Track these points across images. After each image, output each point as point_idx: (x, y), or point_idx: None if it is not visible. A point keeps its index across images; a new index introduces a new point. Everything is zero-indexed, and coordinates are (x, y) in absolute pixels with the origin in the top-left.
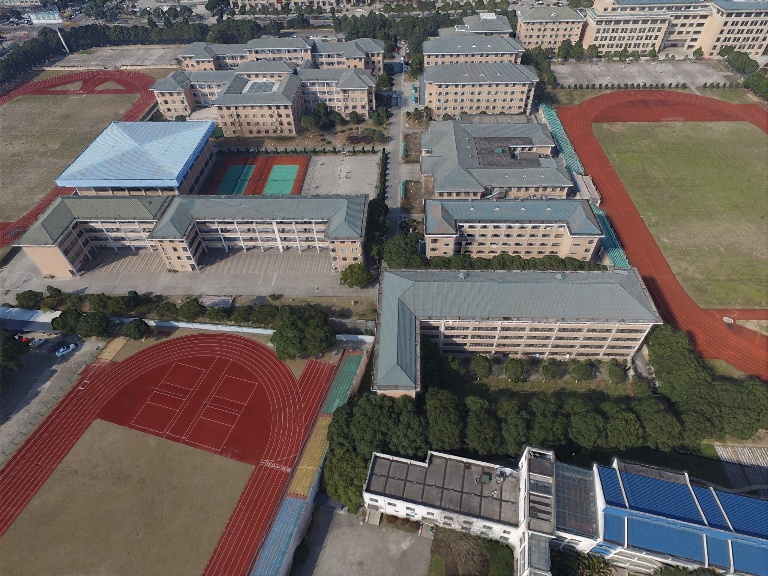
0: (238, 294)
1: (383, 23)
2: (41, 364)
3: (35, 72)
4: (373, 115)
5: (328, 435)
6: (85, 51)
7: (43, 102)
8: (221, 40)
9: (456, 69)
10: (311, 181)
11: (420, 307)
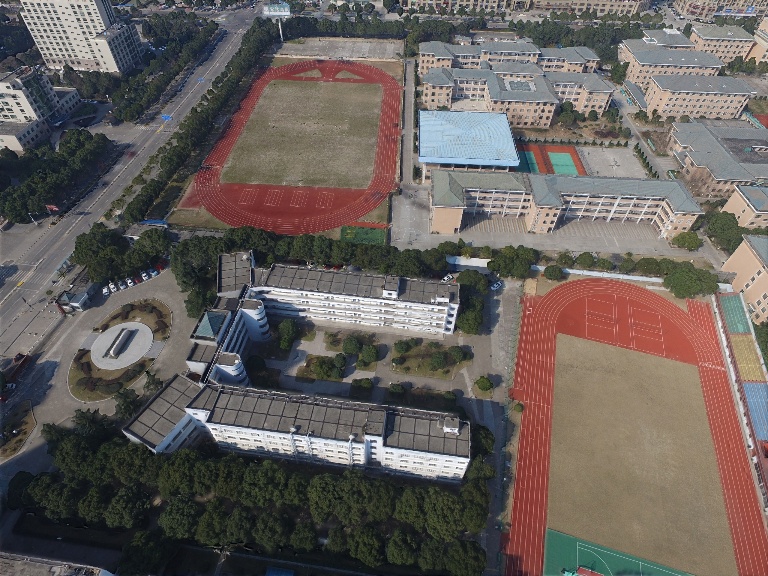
0: (596, 251)
1: (568, 31)
2: (484, 295)
3: (266, 58)
4: (609, 114)
5: (763, 343)
6: (295, 40)
7: (300, 87)
8: (422, 38)
9: (688, 80)
10: (589, 167)
11: None
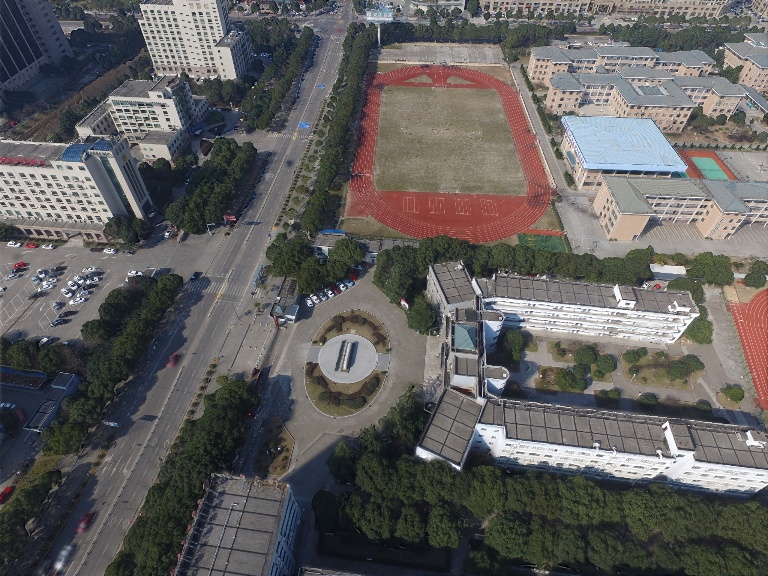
0: None
1: (666, 34)
2: None
3: (370, 64)
4: (737, 118)
5: None
6: (392, 46)
7: (416, 93)
8: (521, 42)
9: None
10: (737, 172)
11: None
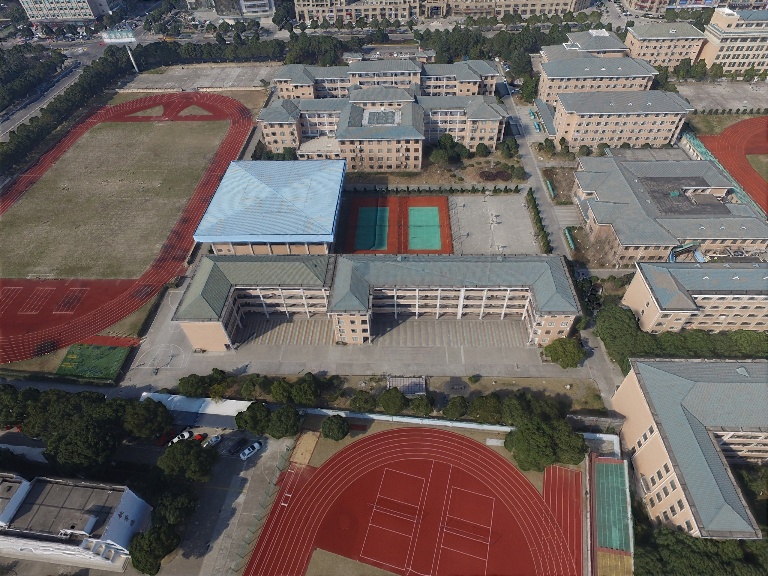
0: (427, 374)
1: (477, 39)
2: (225, 470)
3: (108, 95)
4: (502, 147)
5: None
6: (154, 70)
7: (127, 130)
8: (302, 58)
9: (600, 97)
10: (459, 227)
11: (708, 415)
